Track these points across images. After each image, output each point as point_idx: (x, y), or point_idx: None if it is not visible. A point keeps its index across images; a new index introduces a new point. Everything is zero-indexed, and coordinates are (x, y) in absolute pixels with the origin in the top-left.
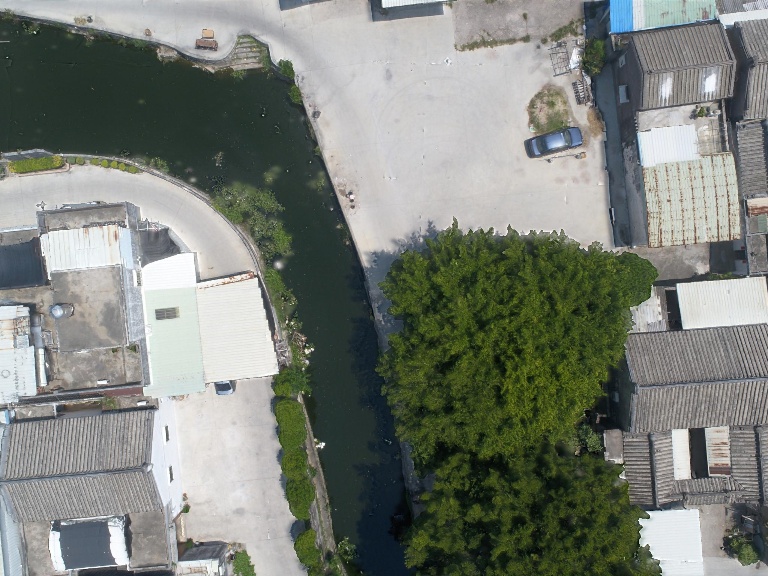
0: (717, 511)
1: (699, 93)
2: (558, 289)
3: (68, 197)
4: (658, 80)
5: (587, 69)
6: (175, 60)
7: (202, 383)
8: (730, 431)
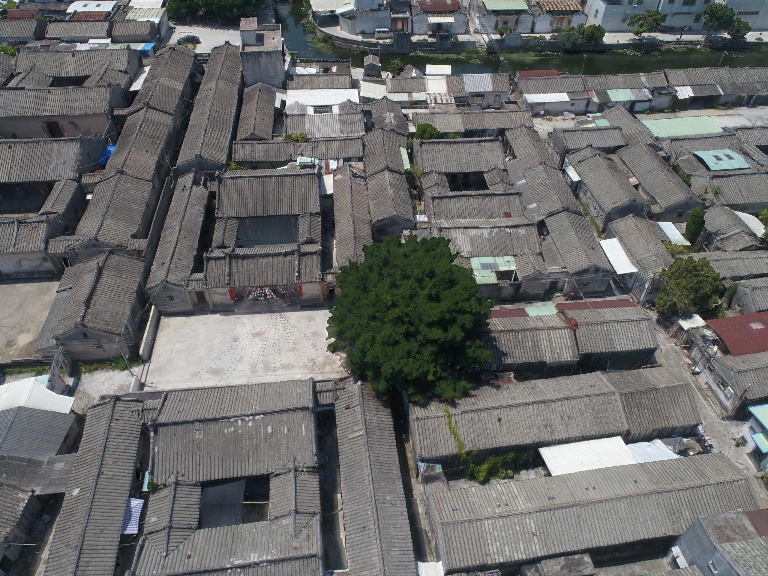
0: None
1: None
2: None
3: None
4: None
5: None
6: None
7: None
8: None
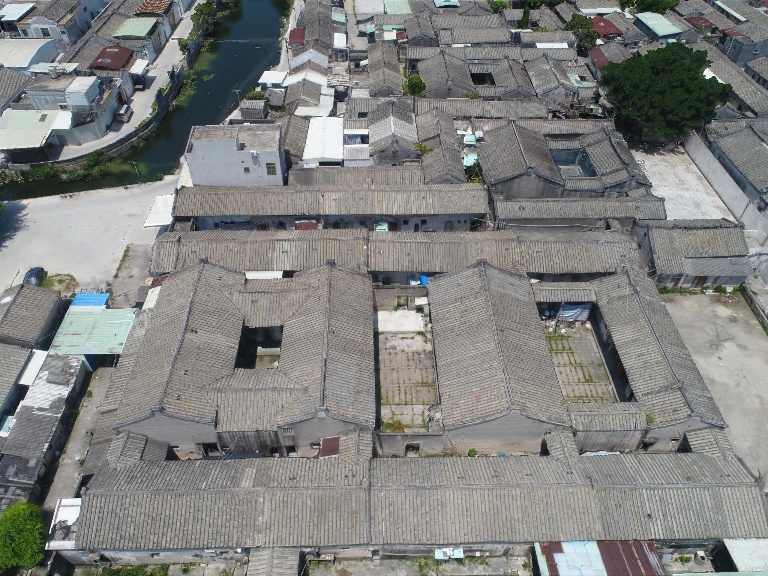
0: None
1: None
2: None
3: (139, 113)
4: None
5: None
6: None
7: (0, 127)
8: None
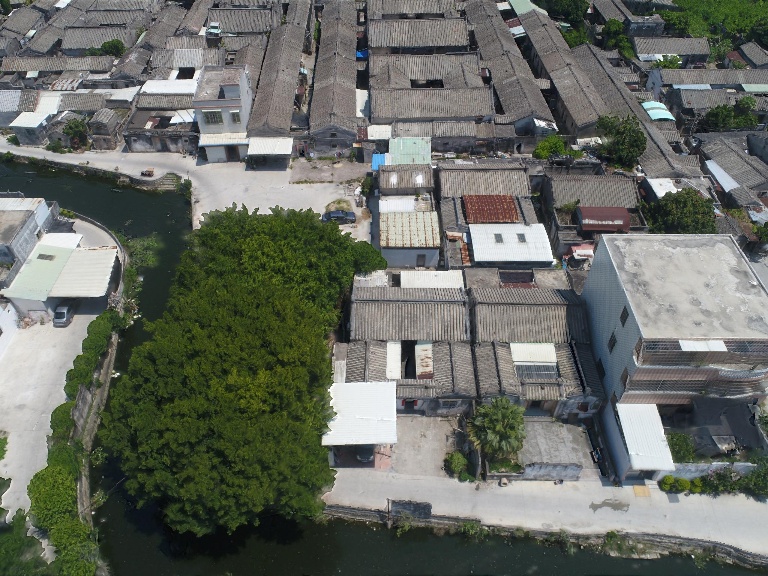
0: (439, 437)
1: (413, 183)
2: (296, 221)
3: None
4: (388, 175)
5: (364, 193)
6: (127, 184)
7: (45, 296)
8: (433, 349)
